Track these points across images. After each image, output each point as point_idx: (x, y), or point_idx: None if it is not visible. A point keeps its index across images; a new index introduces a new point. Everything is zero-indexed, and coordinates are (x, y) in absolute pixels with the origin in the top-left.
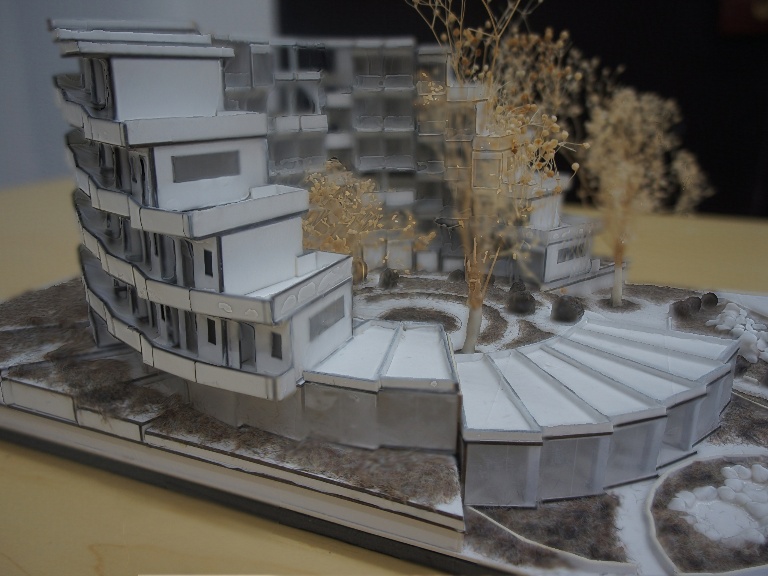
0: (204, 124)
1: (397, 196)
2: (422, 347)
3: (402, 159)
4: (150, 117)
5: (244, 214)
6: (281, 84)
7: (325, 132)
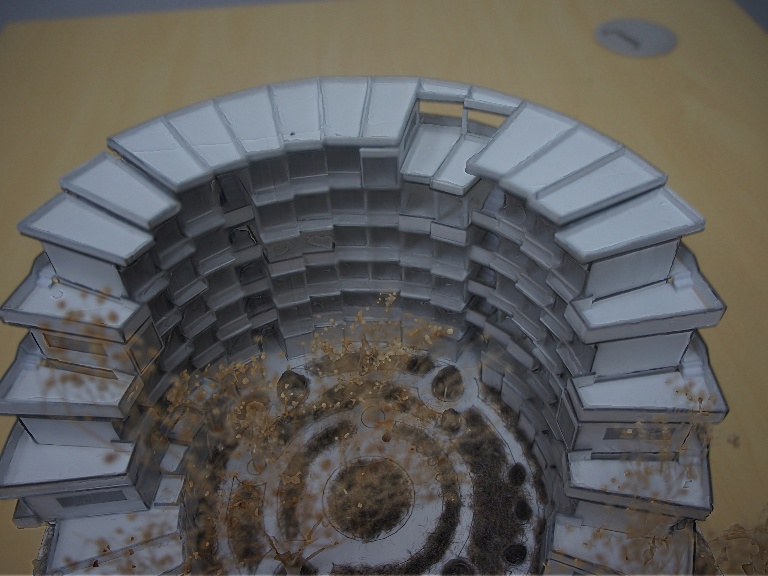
0: (62, 324)
1: (518, 350)
2: (144, 569)
3: (528, 323)
4: (78, 279)
5: (45, 409)
6: (413, 185)
7: (462, 246)
